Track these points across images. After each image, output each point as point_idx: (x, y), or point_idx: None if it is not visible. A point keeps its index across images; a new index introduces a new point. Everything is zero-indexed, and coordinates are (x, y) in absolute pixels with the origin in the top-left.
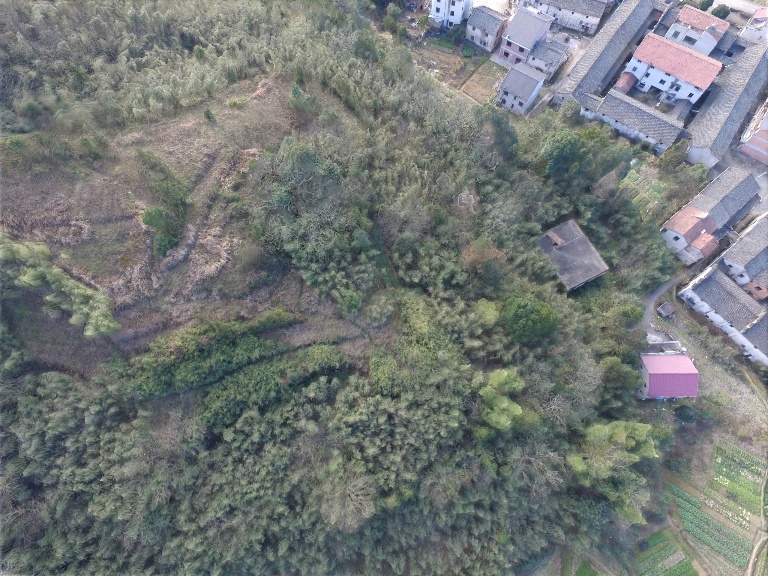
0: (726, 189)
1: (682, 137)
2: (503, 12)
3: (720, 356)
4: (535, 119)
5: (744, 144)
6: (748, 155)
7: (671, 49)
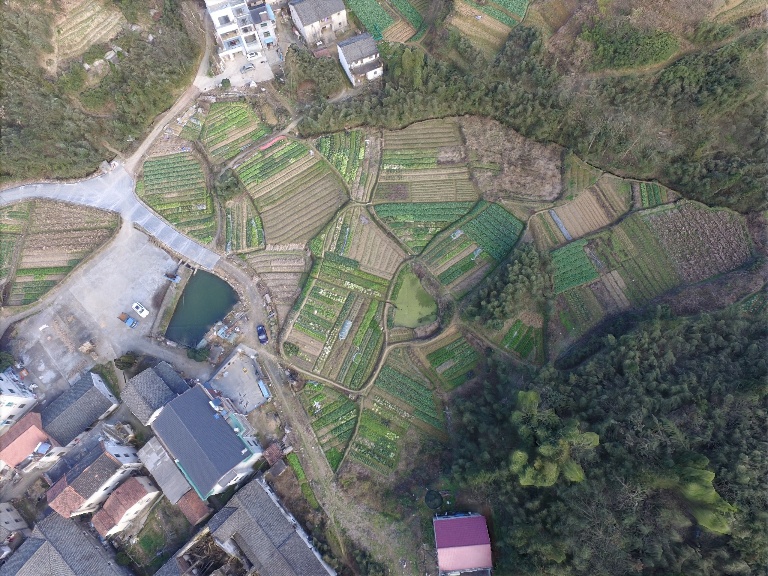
0: None
1: None
2: None
3: (378, 573)
4: None
5: None
6: None
7: None
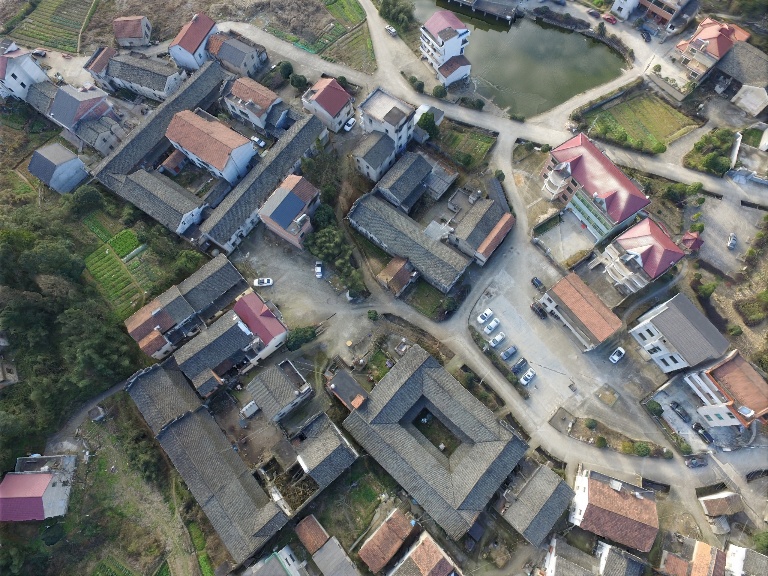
0: (199, 280)
1: (206, 218)
2: (93, 82)
3: (136, 463)
4: (16, 211)
5: (266, 224)
6: (277, 234)
7: (193, 129)
